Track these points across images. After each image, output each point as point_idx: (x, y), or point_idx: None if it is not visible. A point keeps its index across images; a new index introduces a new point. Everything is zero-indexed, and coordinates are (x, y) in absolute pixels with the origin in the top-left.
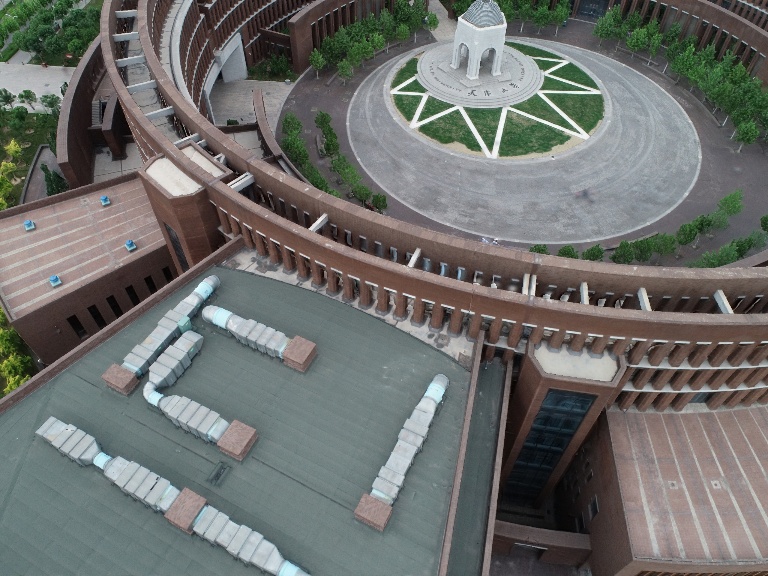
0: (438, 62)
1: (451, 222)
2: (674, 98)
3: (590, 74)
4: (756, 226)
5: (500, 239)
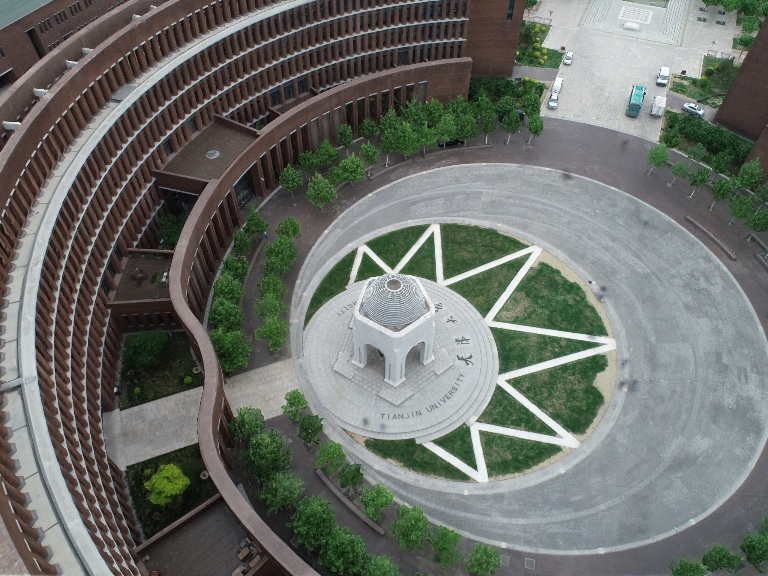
0: (379, 406)
1: (767, 392)
2: (440, 167)
3: (394, 228)
4: (641, 156)
5: (767, 343)
